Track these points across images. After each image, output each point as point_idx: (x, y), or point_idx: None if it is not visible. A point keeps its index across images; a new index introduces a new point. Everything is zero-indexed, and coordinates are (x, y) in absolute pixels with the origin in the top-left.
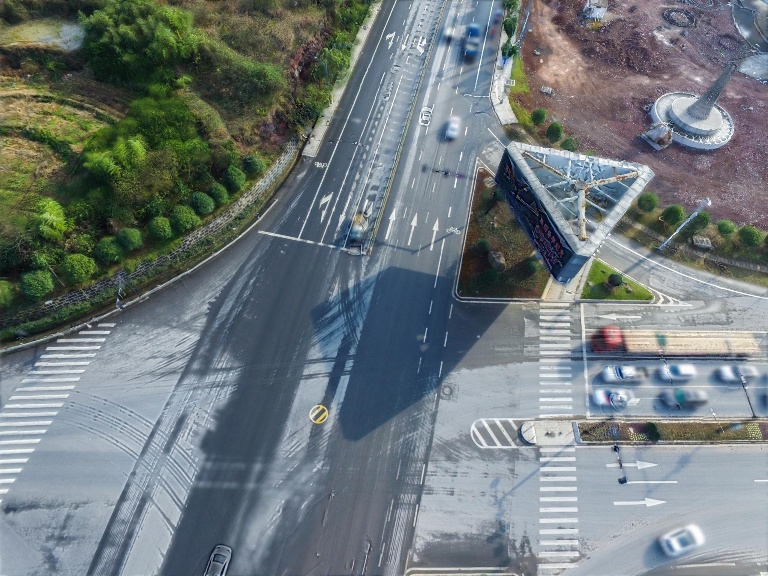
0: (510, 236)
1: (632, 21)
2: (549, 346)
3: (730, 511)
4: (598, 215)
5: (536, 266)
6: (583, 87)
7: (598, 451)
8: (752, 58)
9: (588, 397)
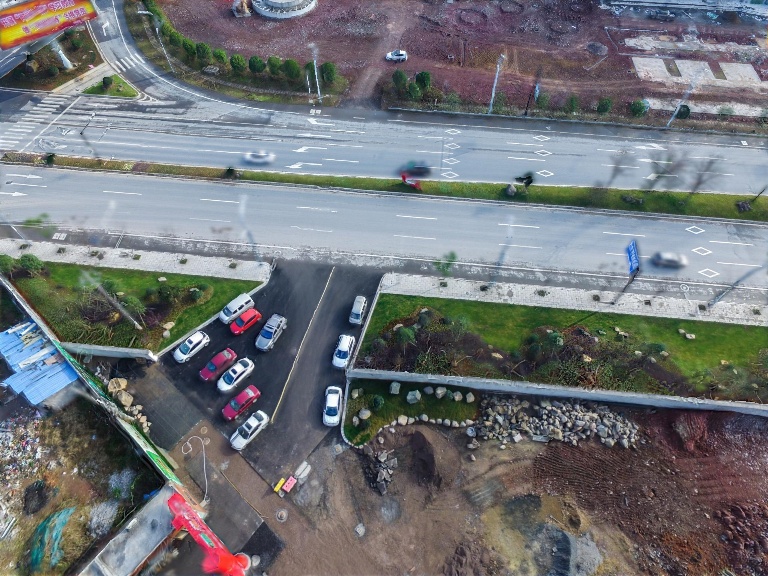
0: (57, 55)
1: None
2: (32, 116)
3: (68, 203)
4: (147, 51)
5: (53, 69)
6: None
7: (8, 168)
8: None
9: (31, 142)
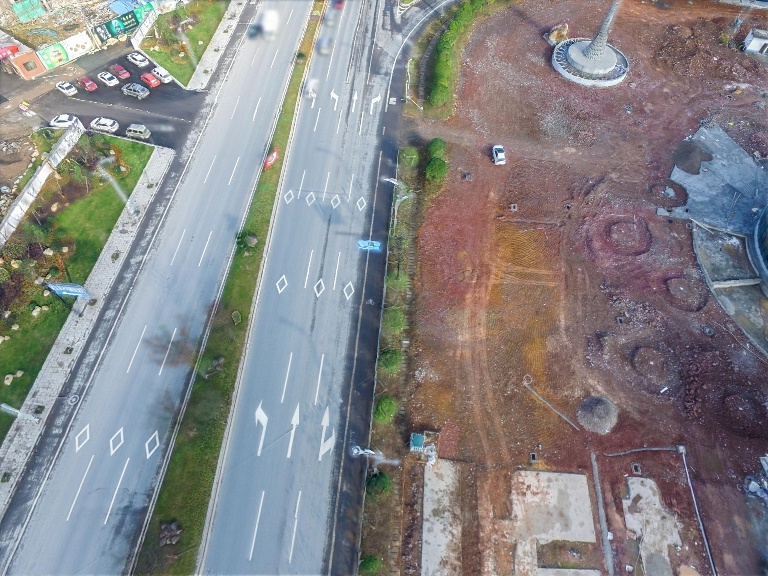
0: None
1: (760, 72)
2: None
3: None
4: None
5: None
6: (616, 17)
7: None
8: (738, 147)
9: None
